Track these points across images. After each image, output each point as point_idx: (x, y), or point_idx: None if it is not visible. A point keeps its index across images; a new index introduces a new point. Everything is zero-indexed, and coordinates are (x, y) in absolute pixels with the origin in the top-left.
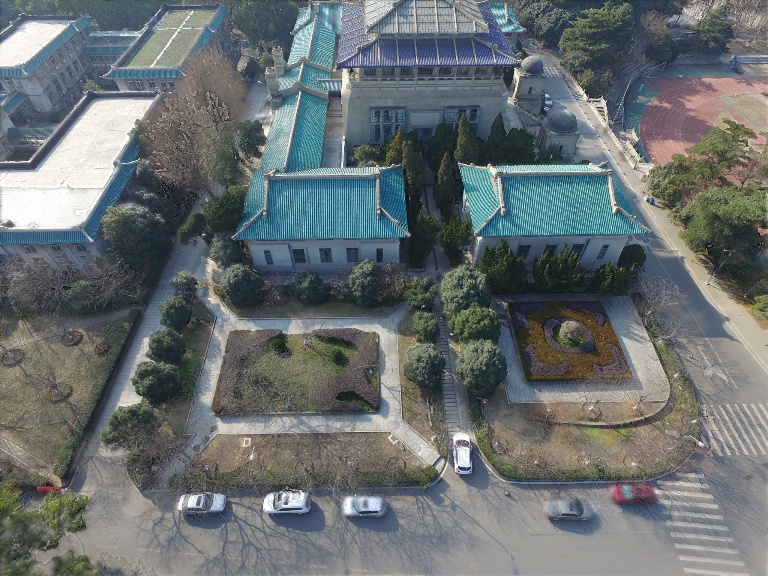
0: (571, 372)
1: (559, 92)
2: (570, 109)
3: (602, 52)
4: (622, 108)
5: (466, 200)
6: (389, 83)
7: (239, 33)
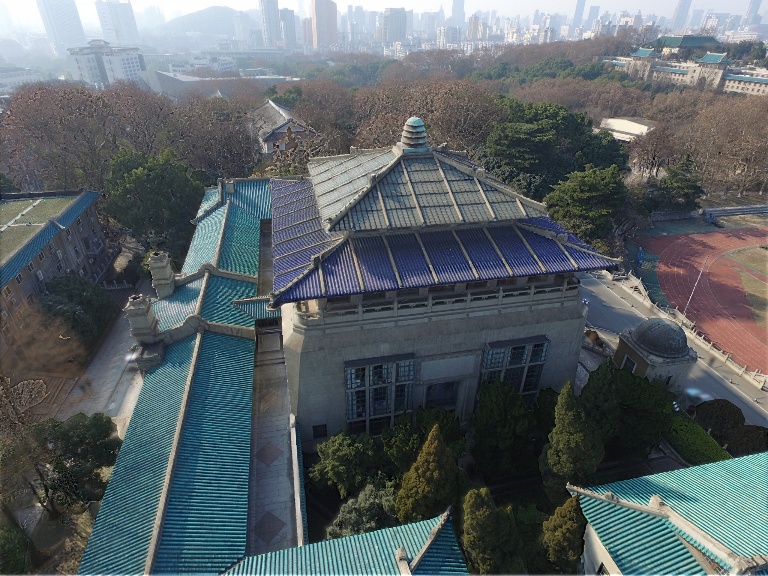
0: None
1: None
2: (599, 293)
3: (604, 218)
4: None
5: (601, 570)
6: (379, 315)
7: None
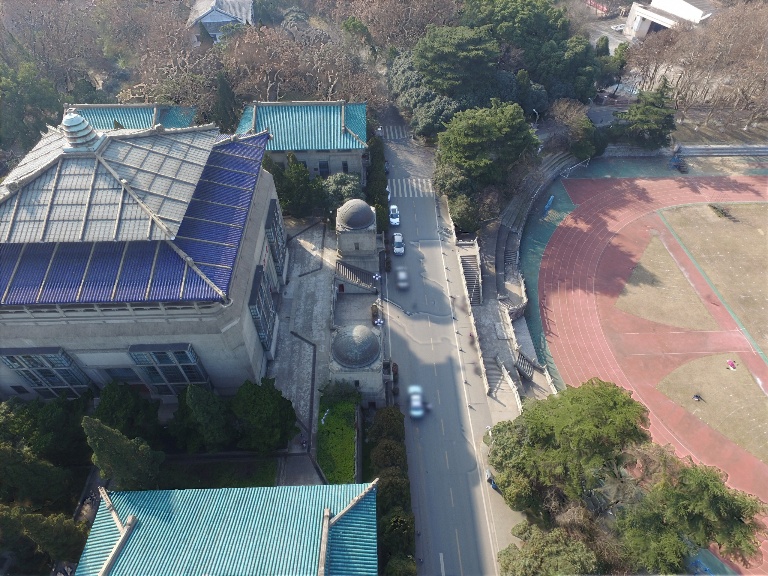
0: None
1: (422, 226)
2: (428, 260)
3: (482, 170)
4: (519, 236)
5: None
6: (17, 315)
7: (53, 115)
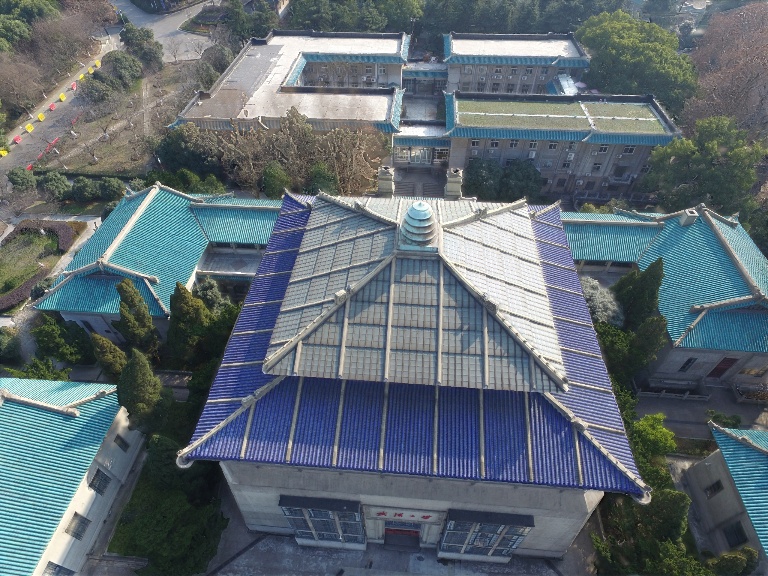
0: None
1: None
2: None
3: None
4: None
5: None
6: None
7: None
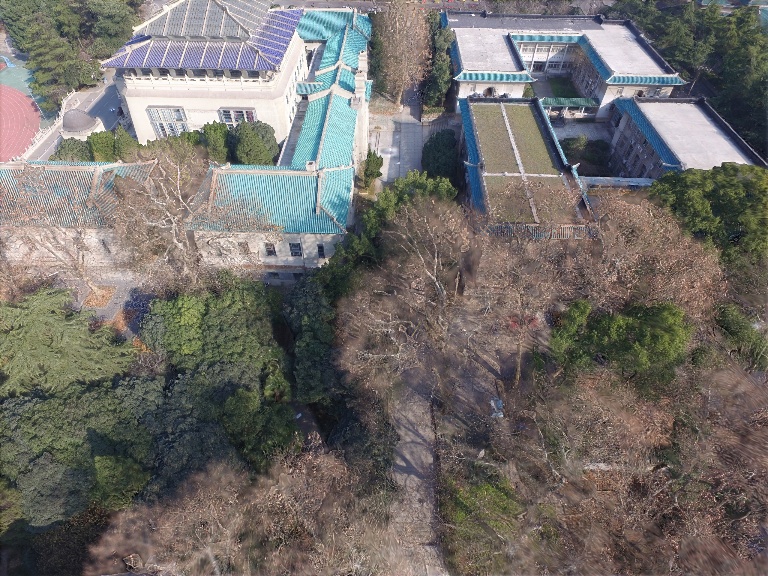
0: None
1: None
2: None
3: None
4: None
5: None
6: None
7: None
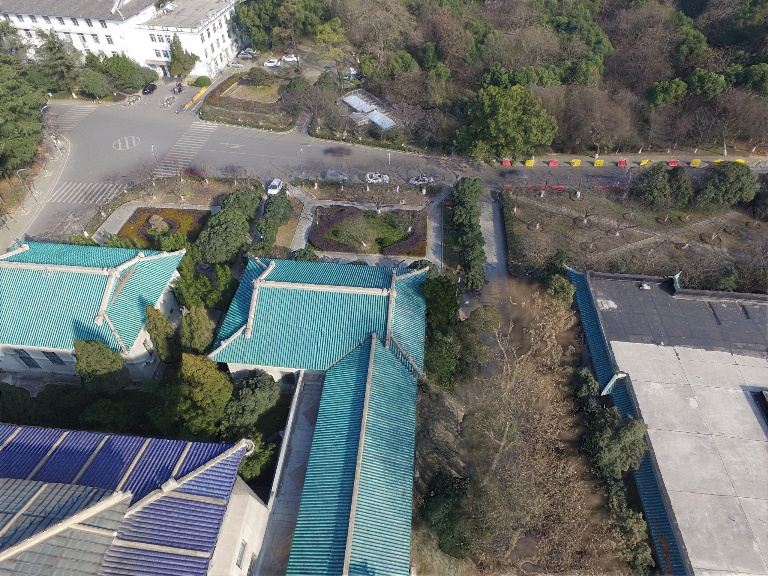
0: (178, 211)
1: None
2: None
3: None
4: None
5: None
6: None
7: None
